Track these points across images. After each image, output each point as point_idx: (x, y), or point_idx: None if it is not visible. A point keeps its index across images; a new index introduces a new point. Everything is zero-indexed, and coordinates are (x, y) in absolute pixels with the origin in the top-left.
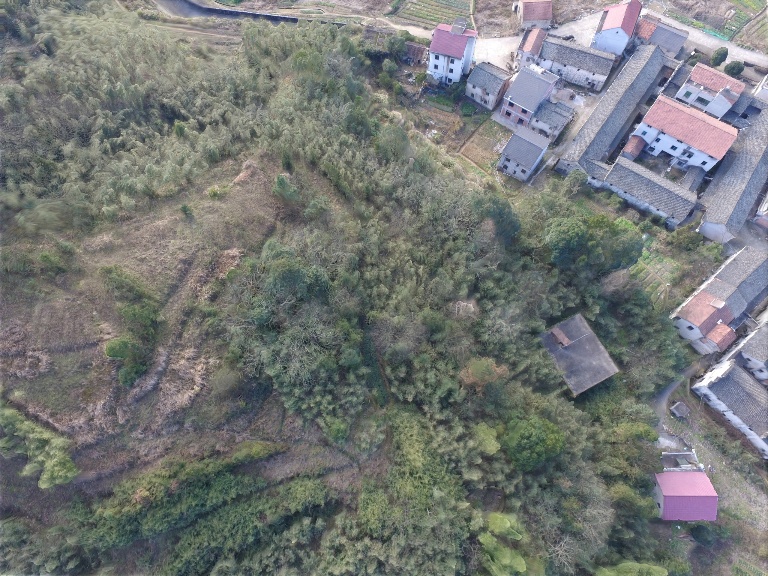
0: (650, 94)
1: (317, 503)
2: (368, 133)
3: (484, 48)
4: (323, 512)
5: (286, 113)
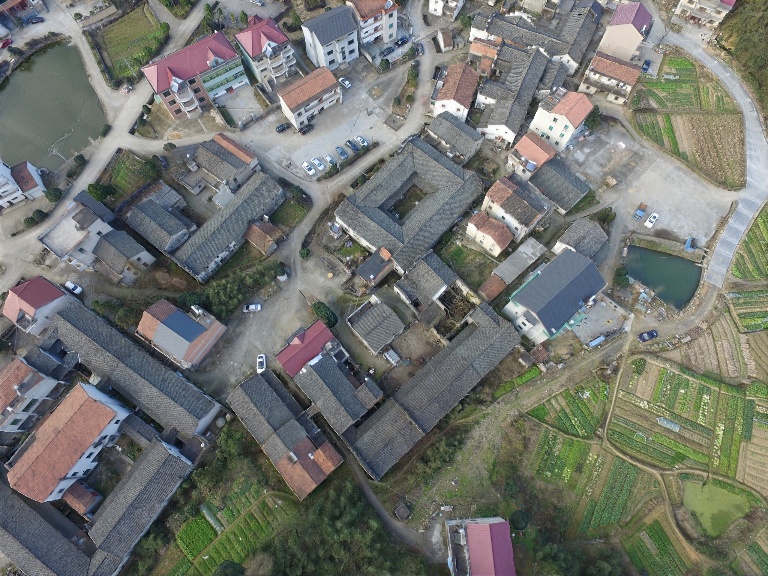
0: (3, 465)
1: None
2: None
3: None
4: None
5: None
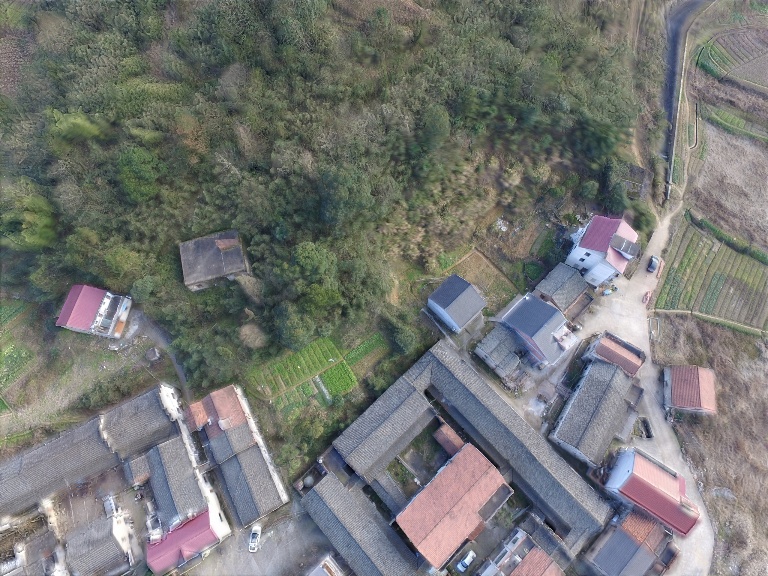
0: (528, 494)
1: (151, 31)
2: (458, 112)
3: (630, 313)
4: (149, 41)
5: (487, 46)
